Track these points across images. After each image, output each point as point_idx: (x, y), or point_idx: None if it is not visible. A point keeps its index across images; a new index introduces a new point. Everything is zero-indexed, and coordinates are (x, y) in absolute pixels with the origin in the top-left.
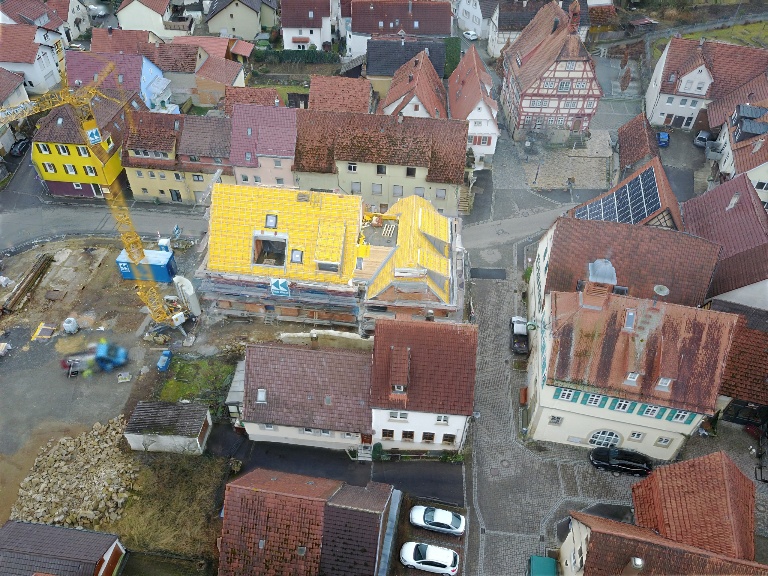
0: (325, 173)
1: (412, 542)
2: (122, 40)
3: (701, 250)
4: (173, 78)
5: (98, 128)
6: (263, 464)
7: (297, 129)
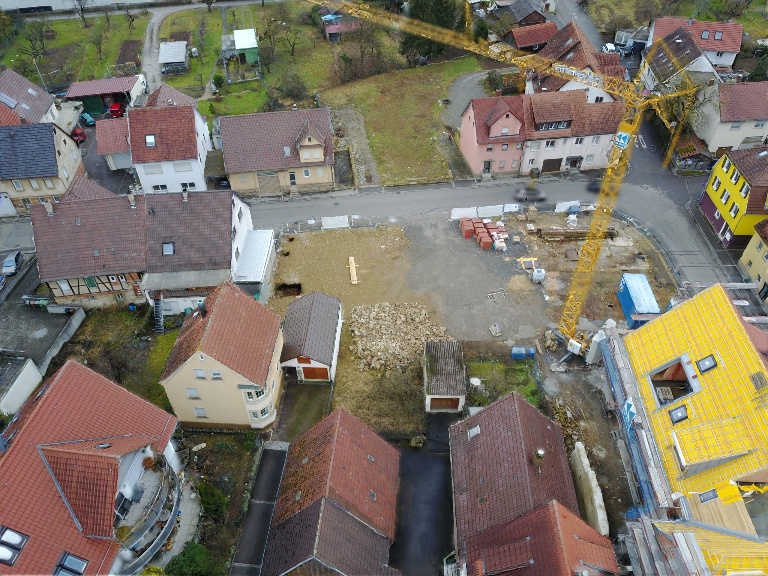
0: None
1: None
2: None
3: None
4: None
5: (630, 135)
6: (425, 467)
7: None
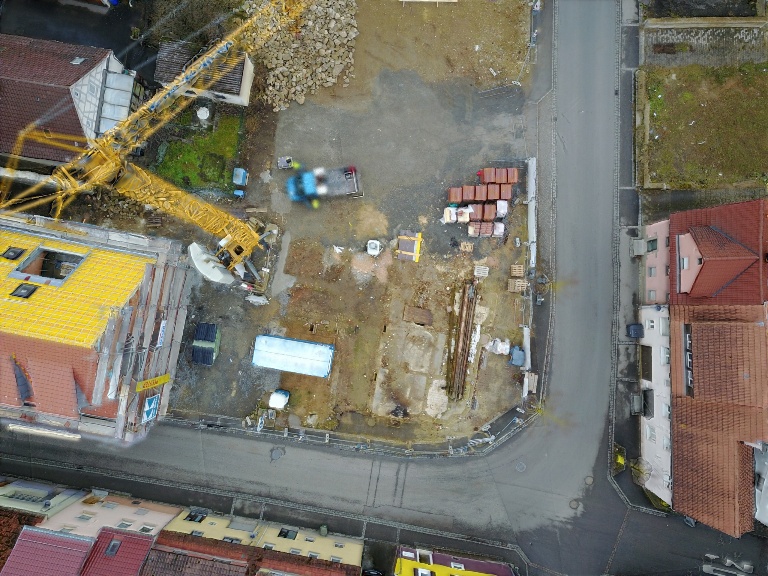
0: None
1: None
2: None
3: None
4: None
5: None
6: (112, 41)
7: None
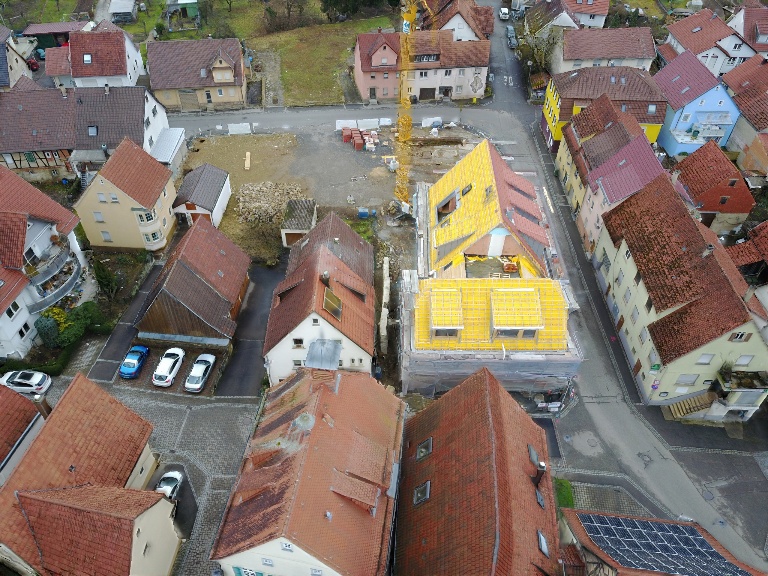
0: (611, 239)
1: (182, 353)
2: (761, 74)
3: (479, 574)
4: (743, 125)
5: (411, 22)
6: (275, 278)
7: (643, 188)
